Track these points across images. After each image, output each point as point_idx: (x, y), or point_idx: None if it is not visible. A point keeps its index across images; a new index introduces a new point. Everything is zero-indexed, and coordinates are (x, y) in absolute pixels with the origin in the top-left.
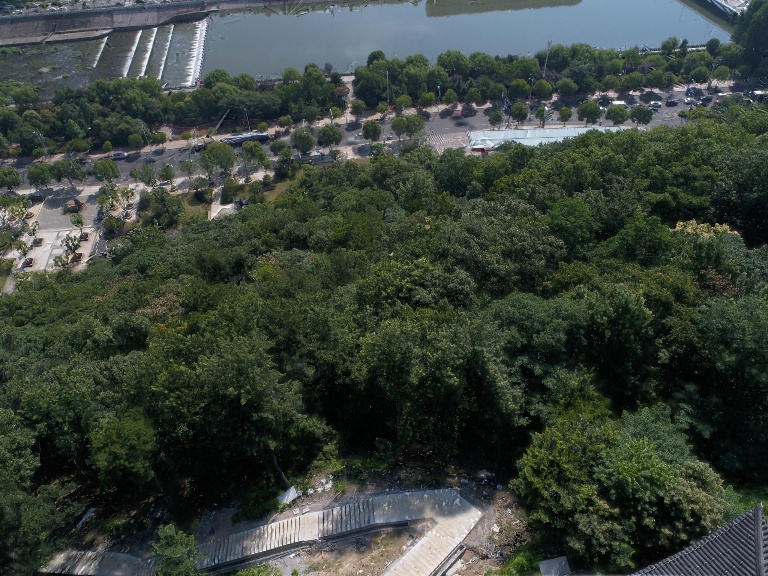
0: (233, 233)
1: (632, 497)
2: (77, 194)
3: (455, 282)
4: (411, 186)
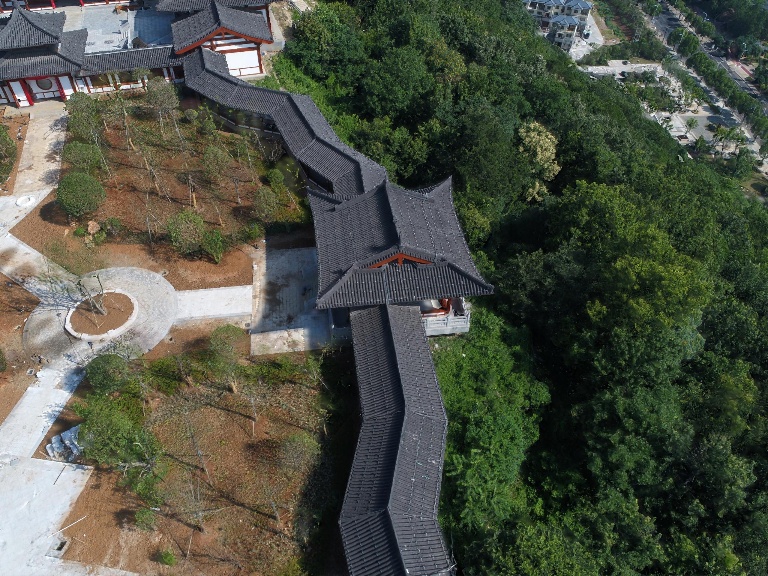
0: (598, 85)
1: None
2: None
3: None
4: (745, 210)
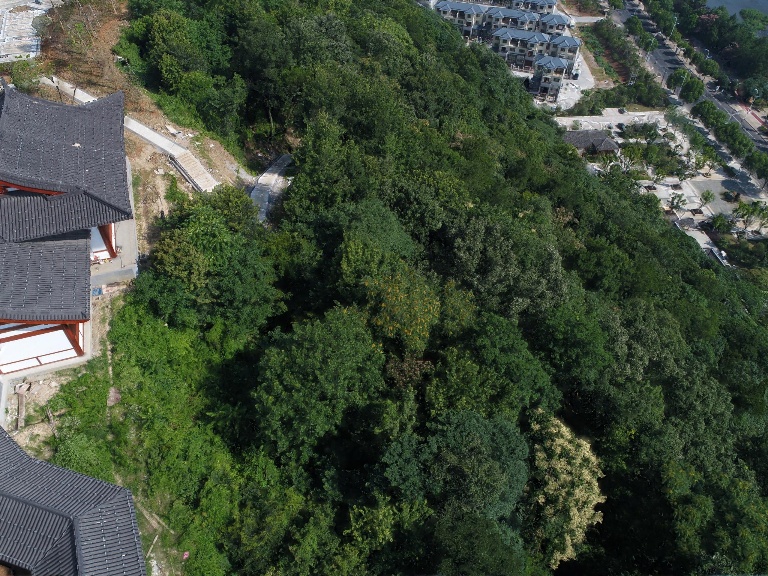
0: None
1: (186, 218)
2: (753, 196)
3: (415, 194)
4: None
